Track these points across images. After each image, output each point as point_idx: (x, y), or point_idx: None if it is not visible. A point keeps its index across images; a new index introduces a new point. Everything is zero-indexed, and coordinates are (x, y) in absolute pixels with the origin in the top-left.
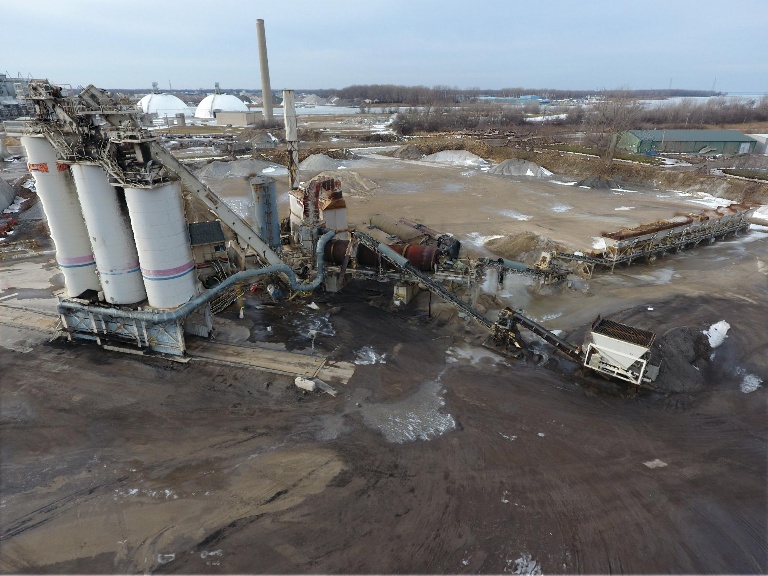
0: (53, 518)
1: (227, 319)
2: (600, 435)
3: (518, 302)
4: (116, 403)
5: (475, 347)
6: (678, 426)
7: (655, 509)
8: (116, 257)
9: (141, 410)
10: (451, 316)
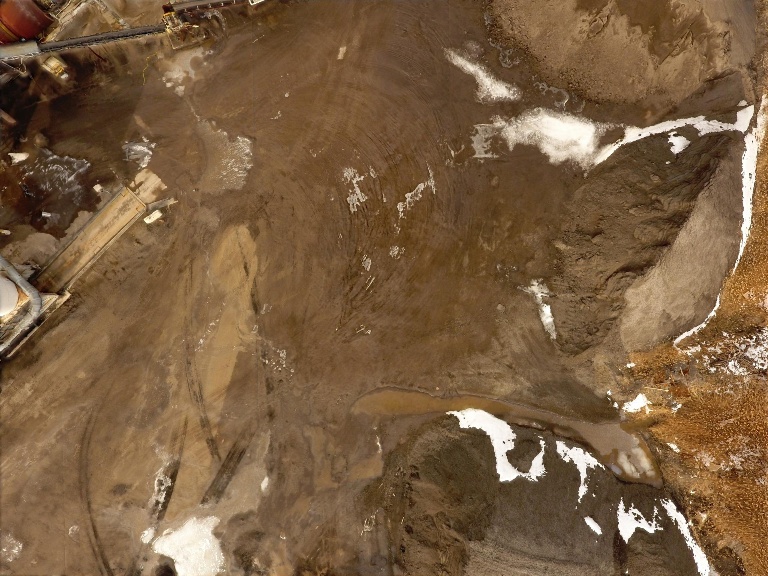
0: (200, 381)
1: (5, 247)
2: (307, 60)
3: None
4: (103, 349)
5: (174, 58)
6: (329, 4)
7: (362, 86)
8: None
9: (122, 333)
10: None
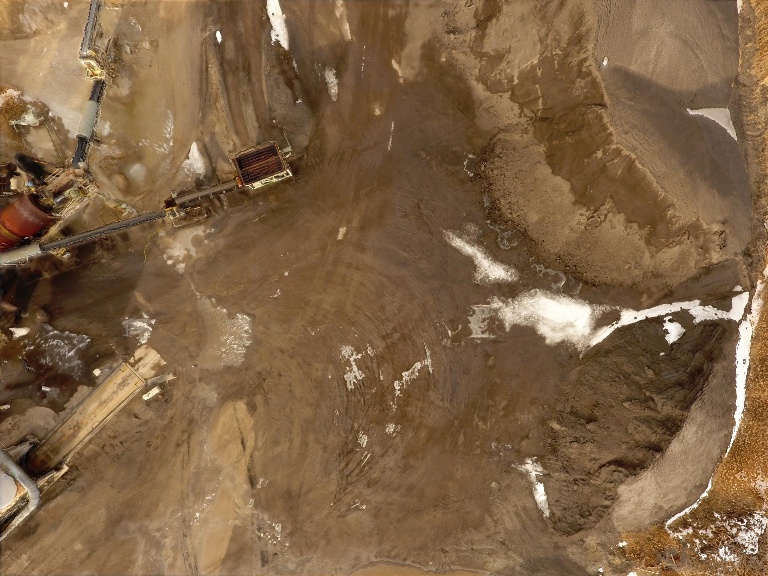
0: (195, 554)
1: (5, 420)
2: (307, 240)
3: (125, 130)
4: (100, 521)
5: (175, 236)
6: (330, 185)
7: (361, 266)
8: None
9: (119, 506)
10: (116, 218)
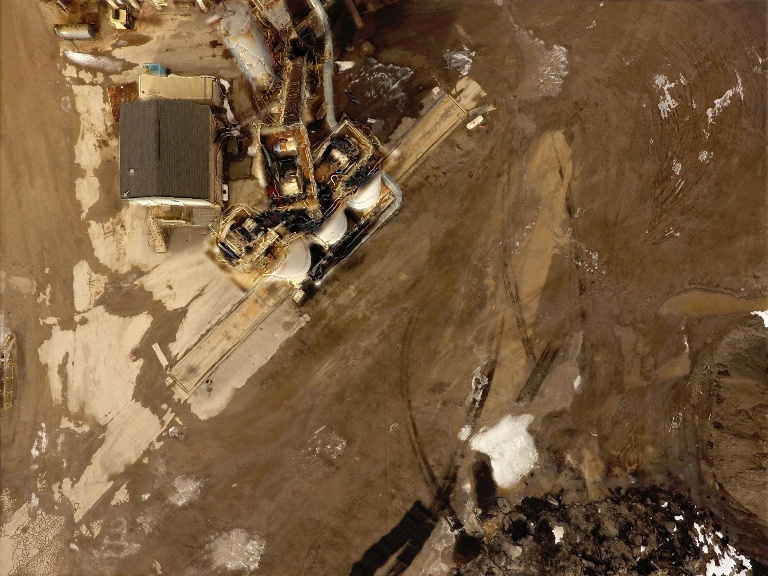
0: (516, 282)
1: None
2: None
3: None
4: (424, 251)
5: None
6: None
7: None
8: (342, 220)
9: (442, 236)
10: None
